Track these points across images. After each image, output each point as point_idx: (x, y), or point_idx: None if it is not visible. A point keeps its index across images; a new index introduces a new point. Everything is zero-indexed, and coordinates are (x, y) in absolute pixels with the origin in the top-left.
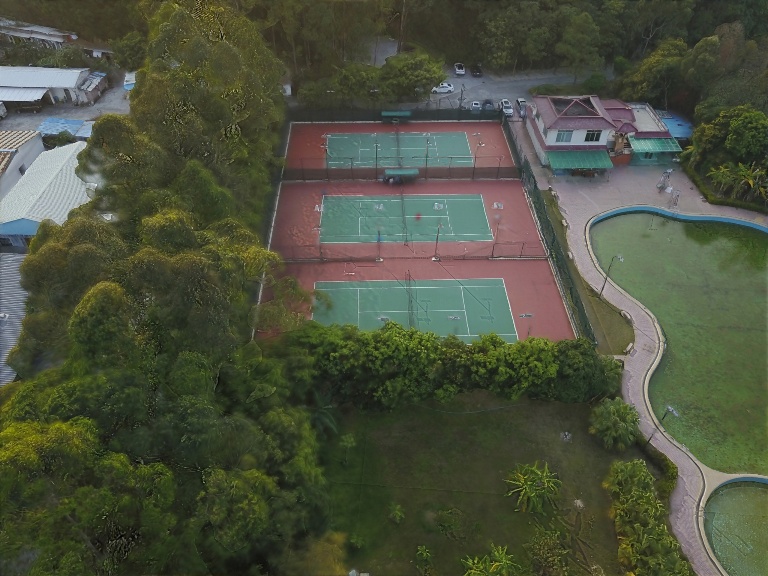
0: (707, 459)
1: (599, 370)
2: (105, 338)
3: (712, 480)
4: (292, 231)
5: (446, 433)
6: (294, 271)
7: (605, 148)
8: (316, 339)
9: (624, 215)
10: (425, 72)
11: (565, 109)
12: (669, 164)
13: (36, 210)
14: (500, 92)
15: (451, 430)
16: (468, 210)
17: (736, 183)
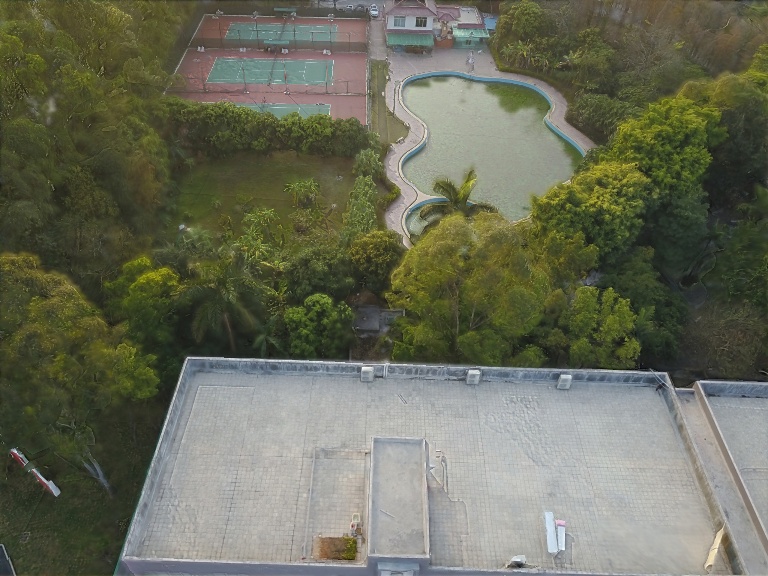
0: (427, 192)
1: (362, 136)
2: (16, 8)
3: (422, 198)
4: (188, 76)
5: (262, 174)
6: (184, 96)
7: (432, 33)
8: (173, 101)
9: (436, 77)
10: None
11: (401, 1)
12: (482, 48)
13: None
14: (376, 3)
15: (266, 173)
16: (320, 68)
17: (517, 55)
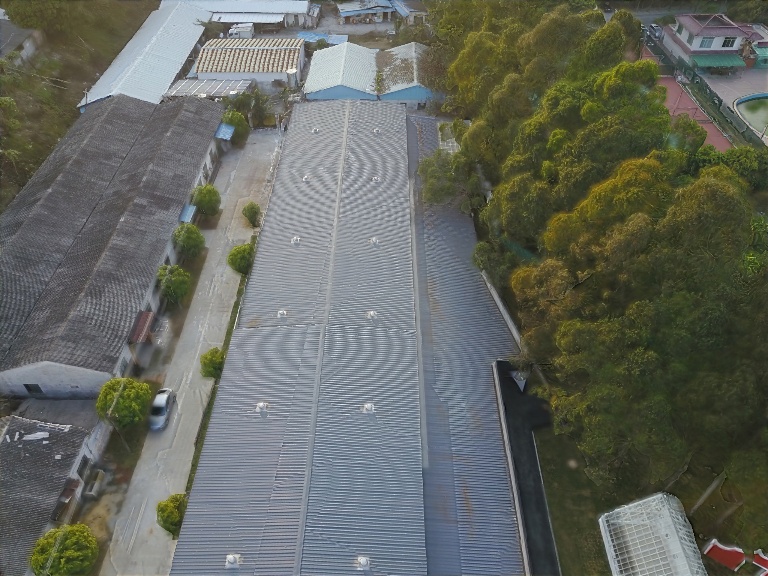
0: None
1: None
2: (609, 53)
3: None
4: None
5: None
6: None
7: (737, 53)
8: None
9: (758, 100)
10: (583, 0)
11: (708, 21)
12: None
13: (345, 81)
14: None
15: None
16: None
17: None
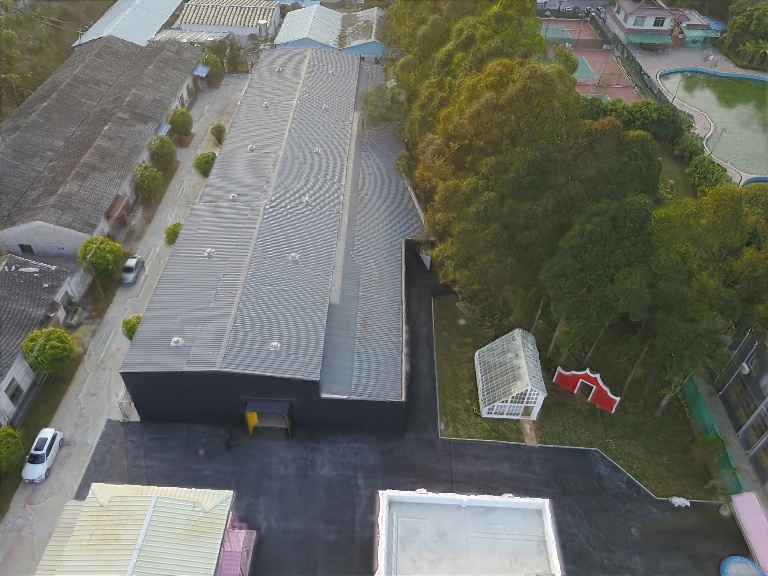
0: None
1: (680, 121)
2: None
3: (746, 176)
4: None
5: None
6: None
7: (666, 32)
8: None
9: (680, 73)
10: None
11: (641, 3)
12: None
13: (311, 35)
14: (581, 6)
15: None
16: None
17: (757, 53)
